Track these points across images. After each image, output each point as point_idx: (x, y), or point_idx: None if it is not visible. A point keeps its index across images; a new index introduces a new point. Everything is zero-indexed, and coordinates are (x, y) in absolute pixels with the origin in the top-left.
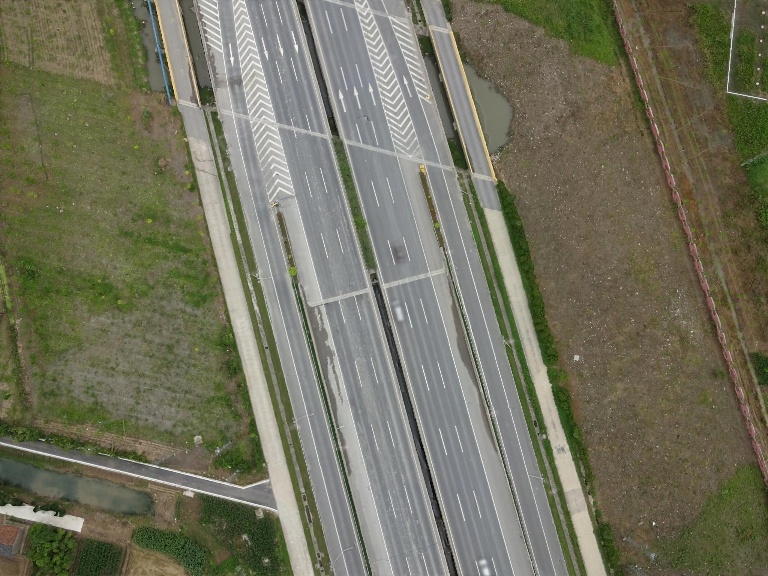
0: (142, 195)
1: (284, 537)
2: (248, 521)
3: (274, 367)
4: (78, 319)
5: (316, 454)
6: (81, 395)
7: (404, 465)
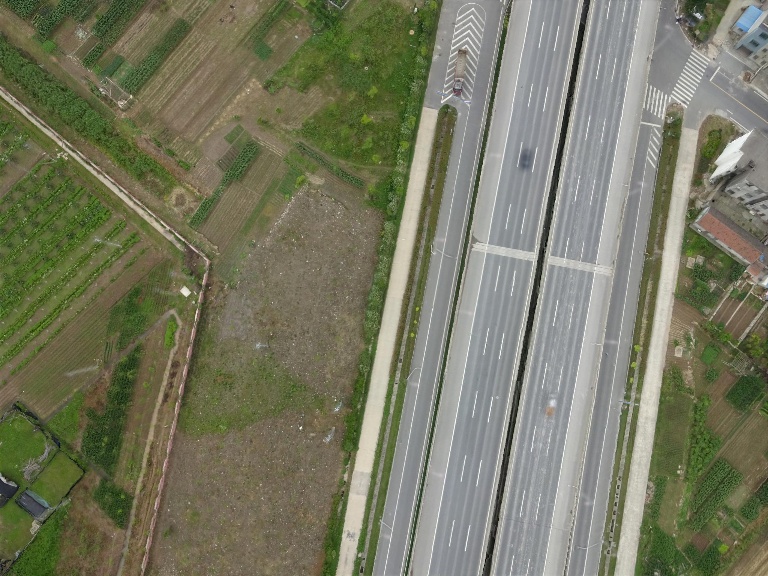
0: None
1: None
2: None
3: None
4: None
5: None
6: None
7: None
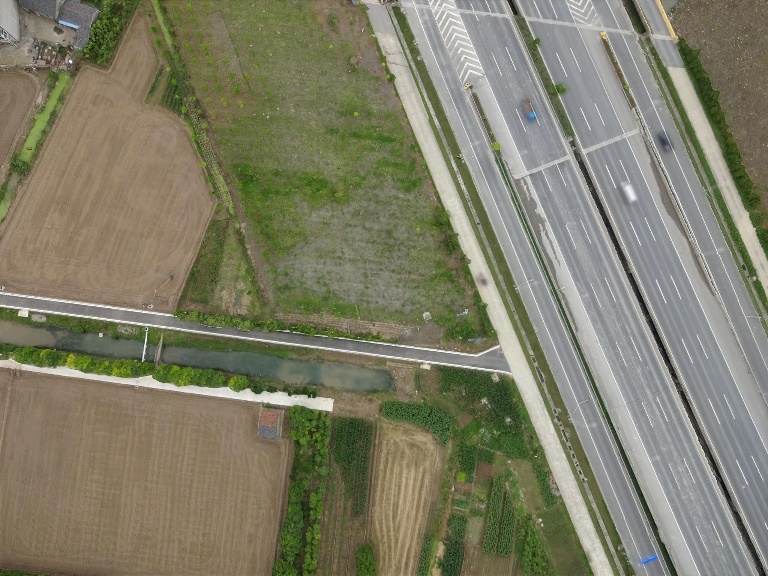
0: (340, 93)
1: (521, 397)
2: (486, 385)
3: (488, 241)
4: (300, 215)
5: (541, 317)
6: (314, 285)
7: (627, 317)
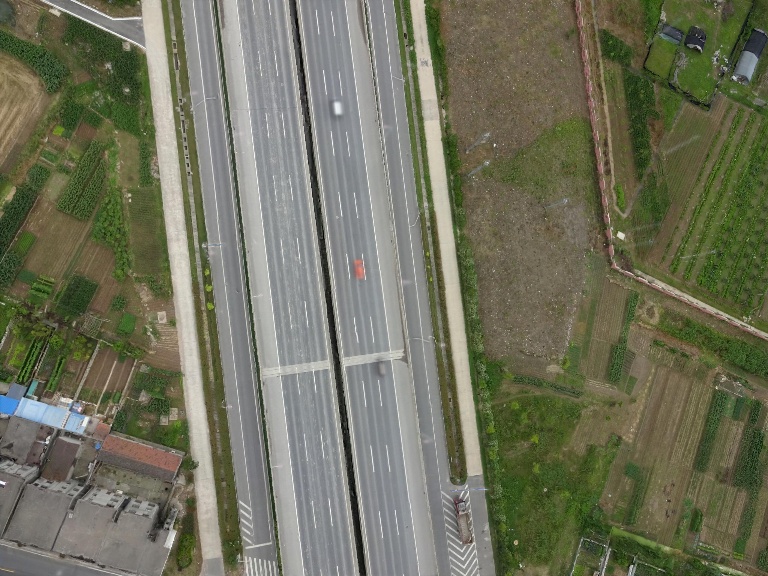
0: None
1: (148, 74)
2: (114, 48)
3: None
4: None
5: (193, 5)
6: None
7: (277, 33)
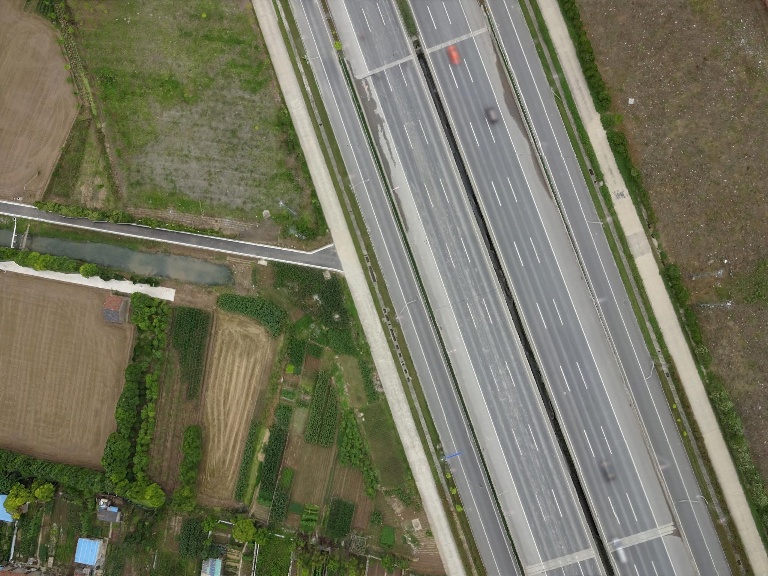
0: None
1: (351, 295)
2: (317, 281)
3: (329, 141)
4: (152, 115)
5: (374, 217)
6: (162, 182)
7: (459, 218)
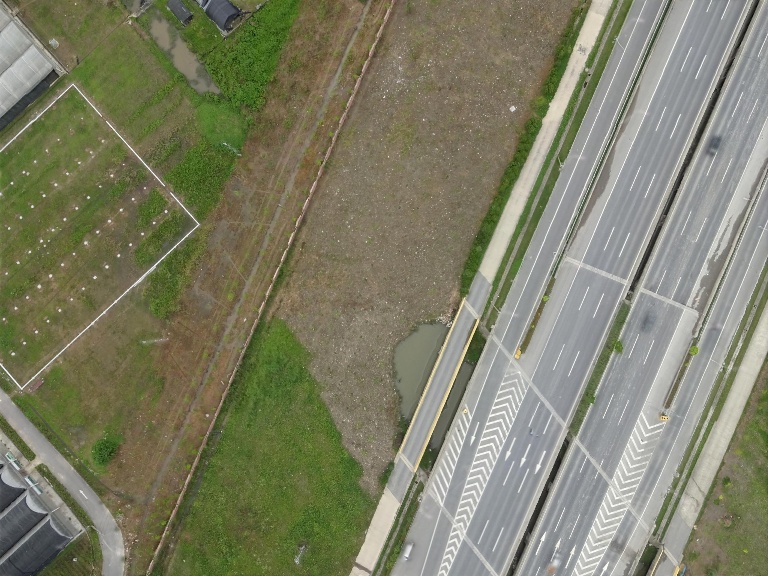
0: (765, 508)
1: None
2: None
3: (760, 287)
4: None
5: None
6: None
7: (720, 133)
